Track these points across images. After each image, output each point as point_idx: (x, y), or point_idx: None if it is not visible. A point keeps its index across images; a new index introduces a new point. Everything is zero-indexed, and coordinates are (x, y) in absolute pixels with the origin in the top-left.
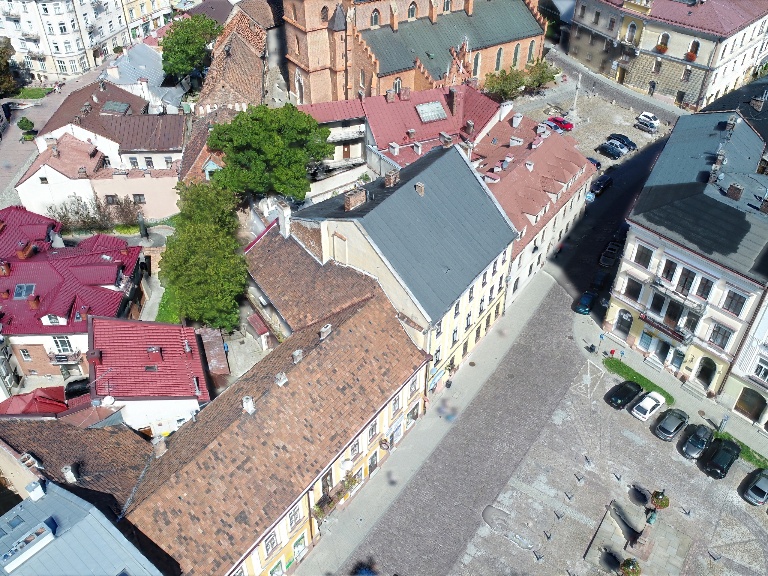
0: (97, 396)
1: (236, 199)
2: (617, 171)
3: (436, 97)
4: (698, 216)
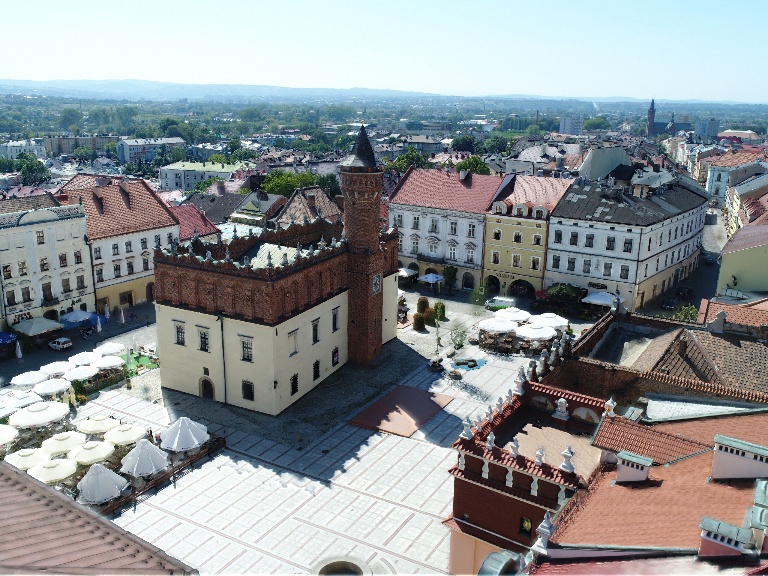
0: None
1: None
2: None
3: None
4: None
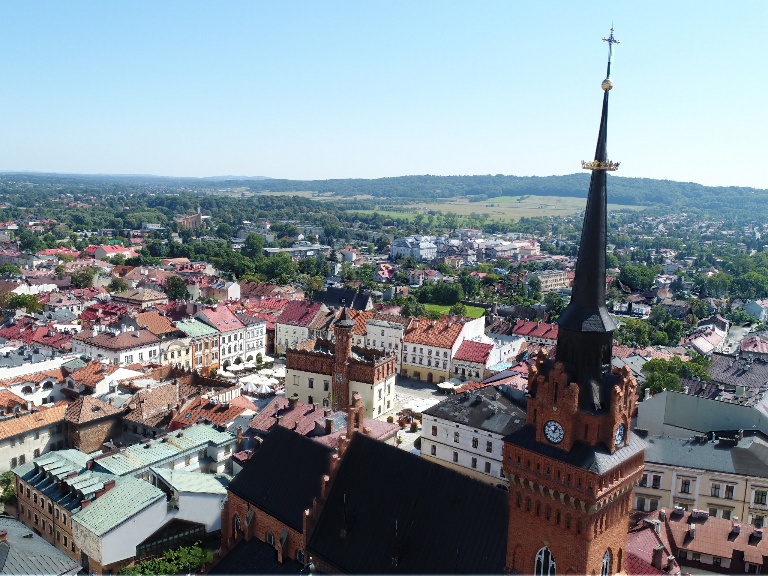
0: None
1: None
2: None
3: (659, 570)
4: (766, 456)
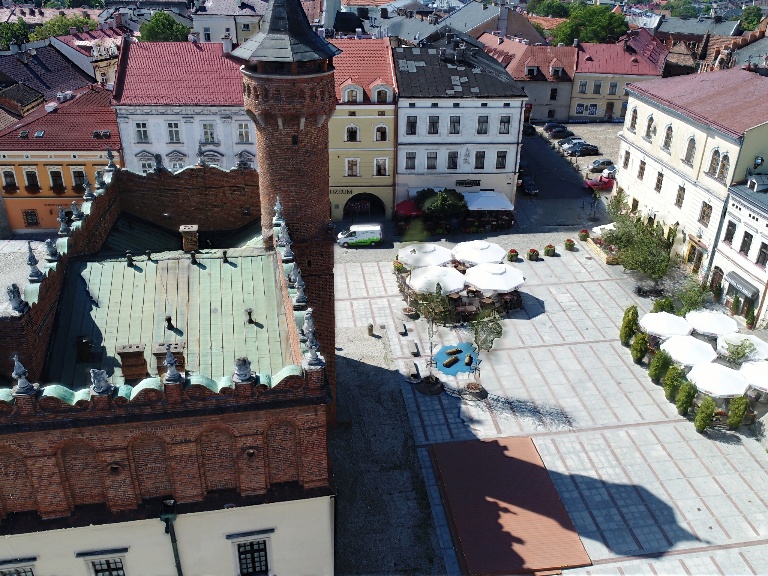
0: None
1: (559, 31)
2: (542, 142)
3: None
4: None
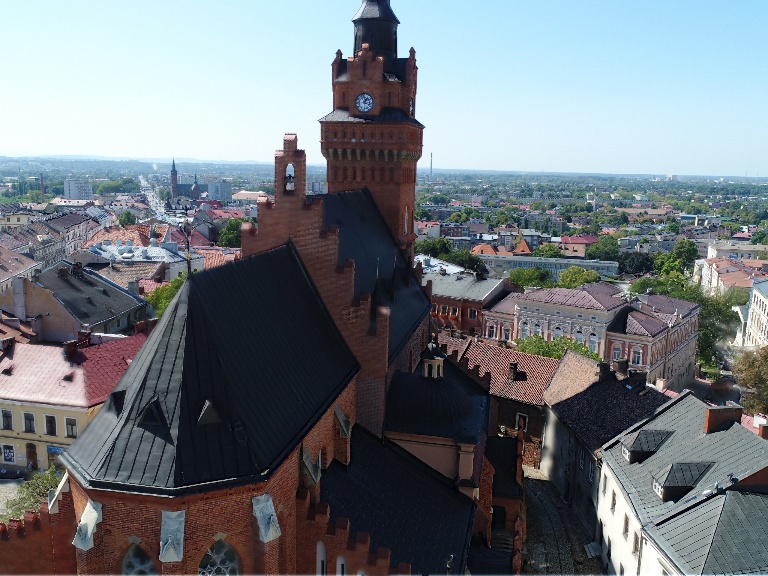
0: (141, 278)
1: None
2: None
3: None
4: None
